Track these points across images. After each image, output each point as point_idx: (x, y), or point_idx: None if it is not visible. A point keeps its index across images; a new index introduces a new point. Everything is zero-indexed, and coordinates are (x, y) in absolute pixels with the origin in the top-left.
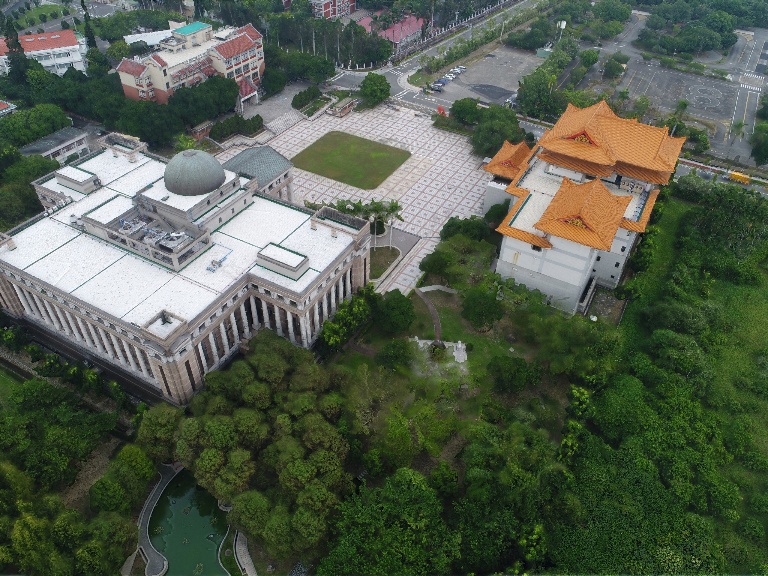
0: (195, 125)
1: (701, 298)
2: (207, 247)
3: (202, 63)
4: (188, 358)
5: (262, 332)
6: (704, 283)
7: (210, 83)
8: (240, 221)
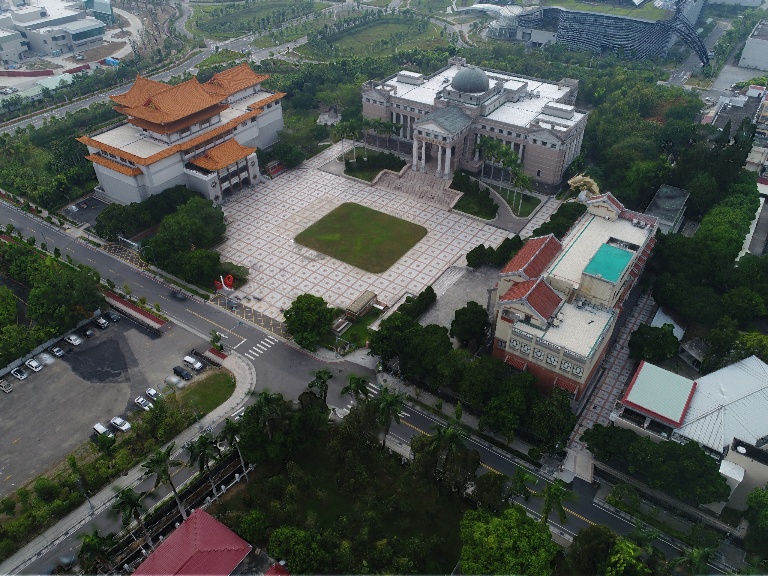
0: None
1: None
2: None
3: None
4: None
5: None
6: None
7: None
8: None
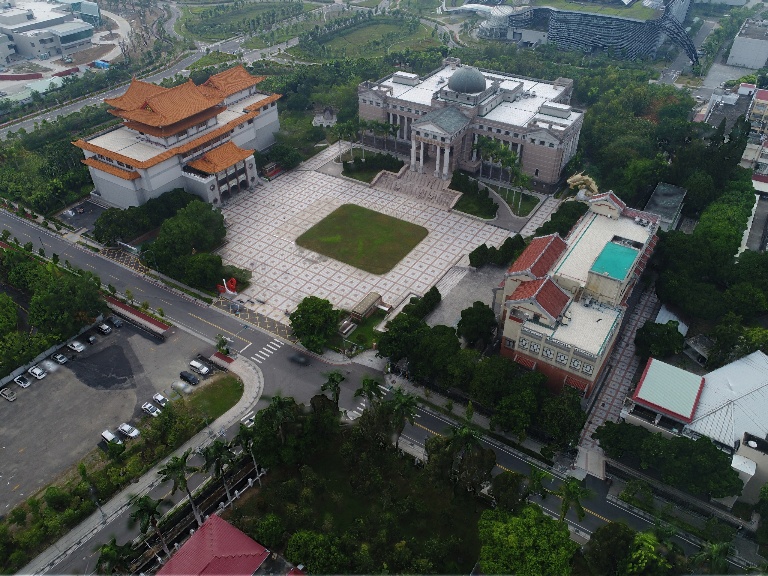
0: None
1: None
2: None
3: None
4: None
5: None
6: None
7: None
8: None
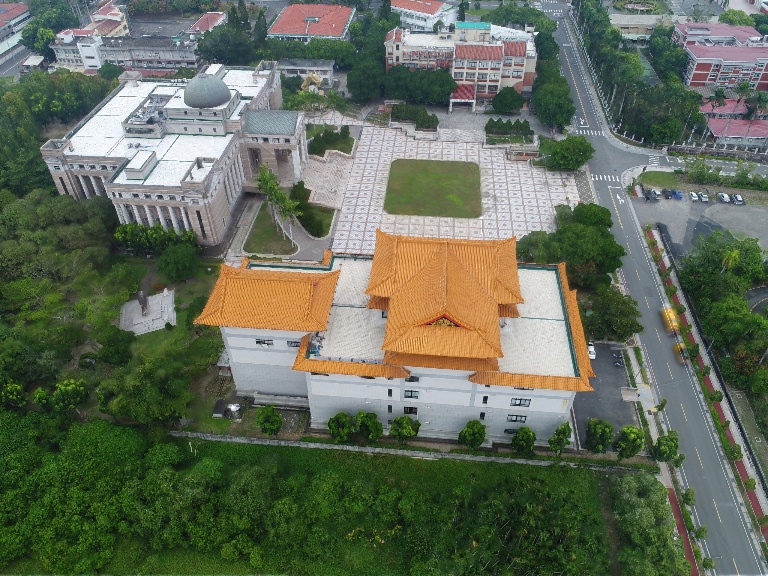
0: (391, 98)
1: (343, 531)
2: (155, 136)
3: (441, 54)
4: (62, 176)
5: (100, 196)
6: (375, 531)
7: (434, 73)
8: (196, 139)
